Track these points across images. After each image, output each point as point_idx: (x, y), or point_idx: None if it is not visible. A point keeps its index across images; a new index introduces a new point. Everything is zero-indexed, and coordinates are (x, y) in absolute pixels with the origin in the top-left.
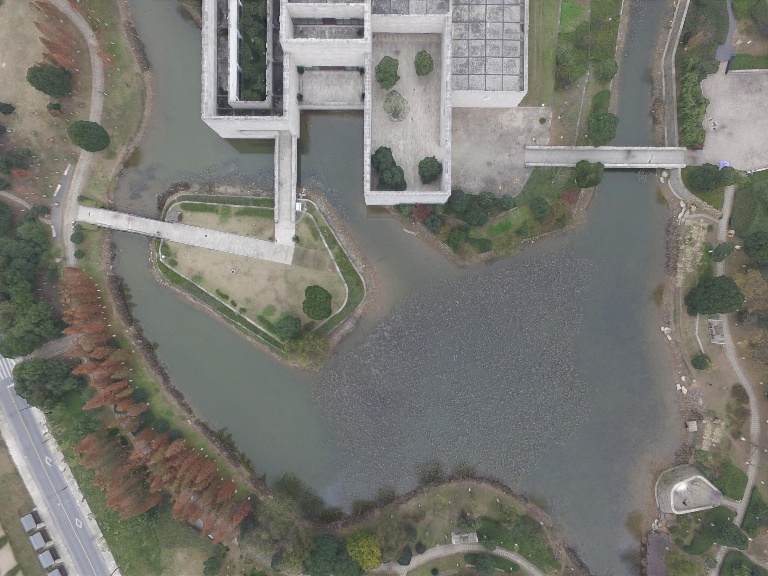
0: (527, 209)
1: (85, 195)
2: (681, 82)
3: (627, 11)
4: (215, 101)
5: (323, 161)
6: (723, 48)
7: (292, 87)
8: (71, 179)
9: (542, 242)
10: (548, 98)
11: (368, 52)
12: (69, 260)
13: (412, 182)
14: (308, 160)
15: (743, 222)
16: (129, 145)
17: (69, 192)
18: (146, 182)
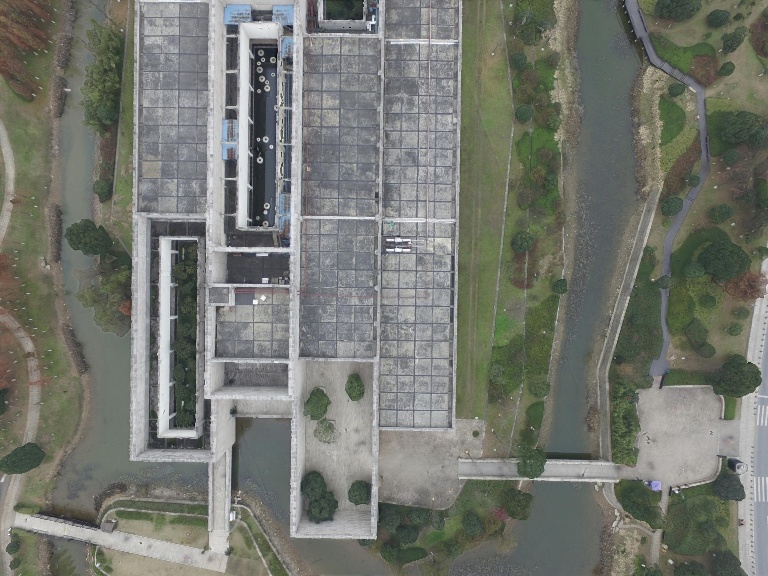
0: (460, 518)
1: (22, 501)
2: (613, 405)
3: (563, 319)
4: (147, 427)
5: (259, 464)
6: (657, 362)
7: (222, 417)
8: (8, 485)
9: (476, 547)
10: (482, 411)
11: (295, 397)
12: (6, 565)
13: (346, 492)
14: (244, 463)
15: (676, 538)
16: (67, 447)
17: (6, 498)
18: (83, 482)
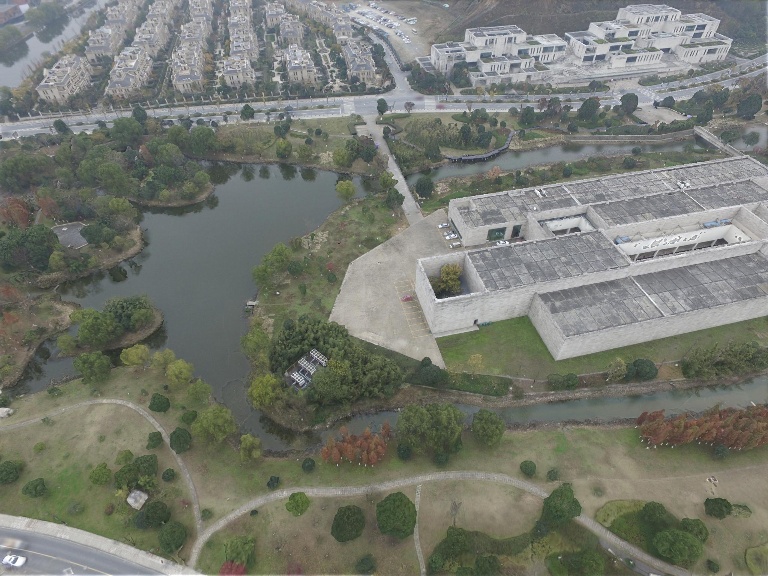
0: None
1: None
2: None
3: None
4: None
5: None
6: None
7: None
8: None
9: None
10: None
11: None
12: None
13: None
14: None
15: (702, 111)
16: None
17: None
18: None
